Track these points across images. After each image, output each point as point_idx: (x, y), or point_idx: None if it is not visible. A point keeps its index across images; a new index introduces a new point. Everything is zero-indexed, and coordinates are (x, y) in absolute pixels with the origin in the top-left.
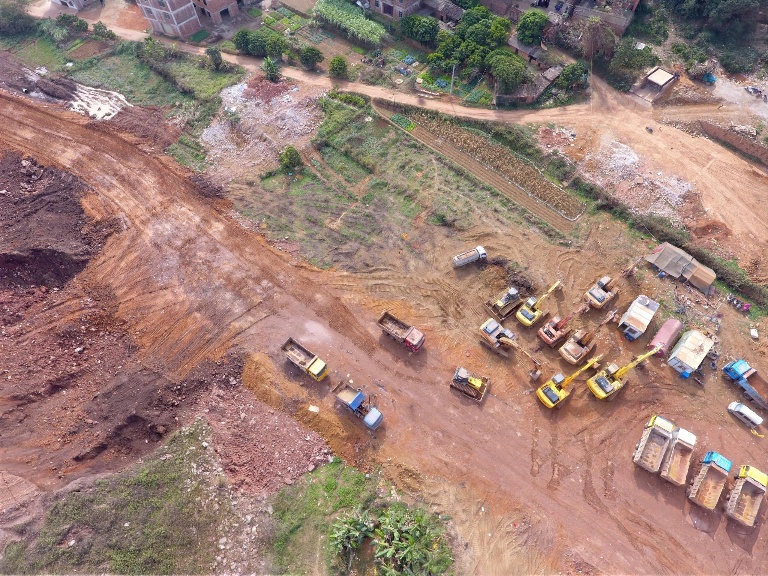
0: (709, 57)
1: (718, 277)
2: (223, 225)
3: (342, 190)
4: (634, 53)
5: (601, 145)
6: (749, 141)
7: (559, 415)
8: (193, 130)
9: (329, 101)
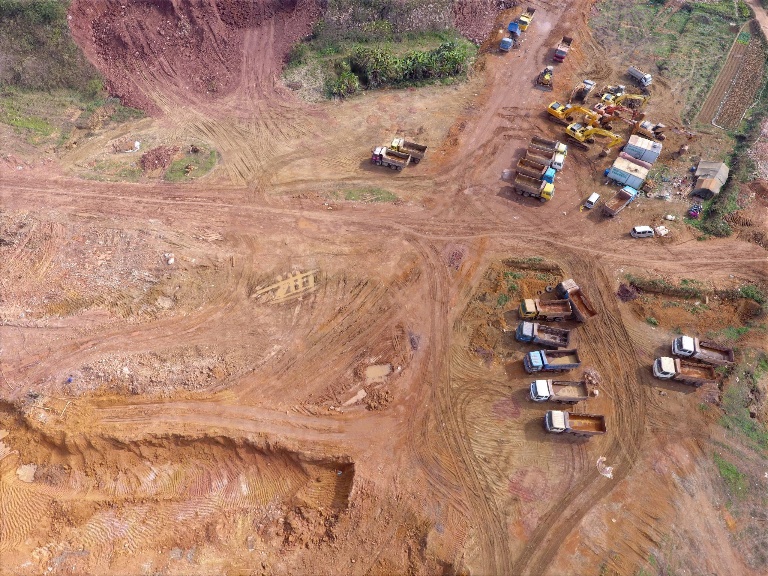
0: None
1: None
2: None
3: (655, 23)
4: None
5: None
6: None
7: (545, 120)
8: None
9: (733, 3)
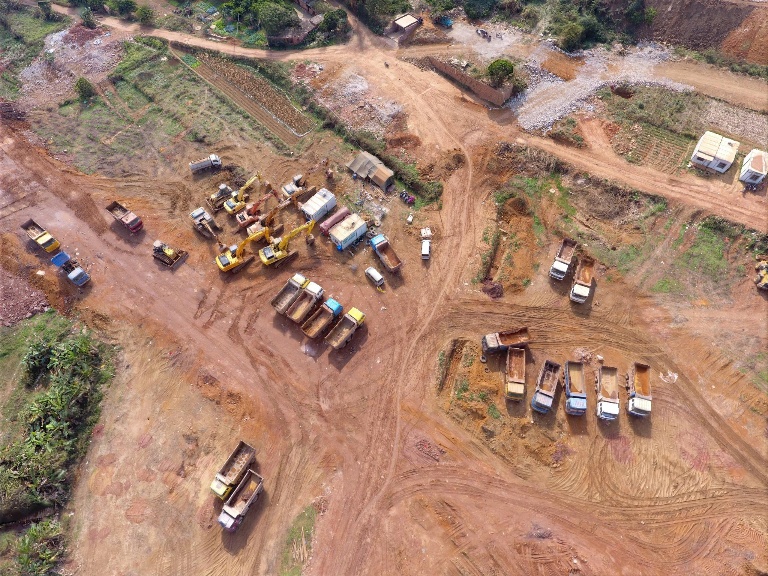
0: (457, 5)
1: (398, 178)
2: (13, 140)
3: (123, 114)
4: (390, 1)
5: (341, 77)
6: (460, 72)
7: (234, 278)
8: (15, 68)
9: (134, 44)
